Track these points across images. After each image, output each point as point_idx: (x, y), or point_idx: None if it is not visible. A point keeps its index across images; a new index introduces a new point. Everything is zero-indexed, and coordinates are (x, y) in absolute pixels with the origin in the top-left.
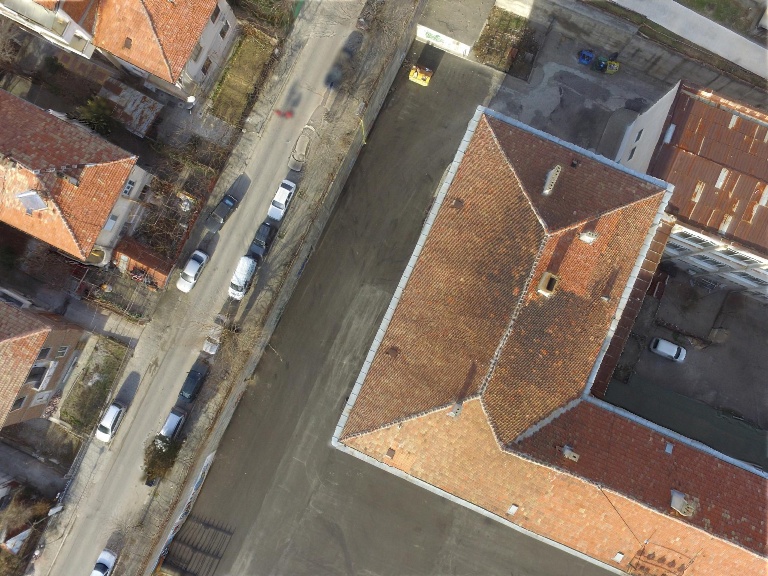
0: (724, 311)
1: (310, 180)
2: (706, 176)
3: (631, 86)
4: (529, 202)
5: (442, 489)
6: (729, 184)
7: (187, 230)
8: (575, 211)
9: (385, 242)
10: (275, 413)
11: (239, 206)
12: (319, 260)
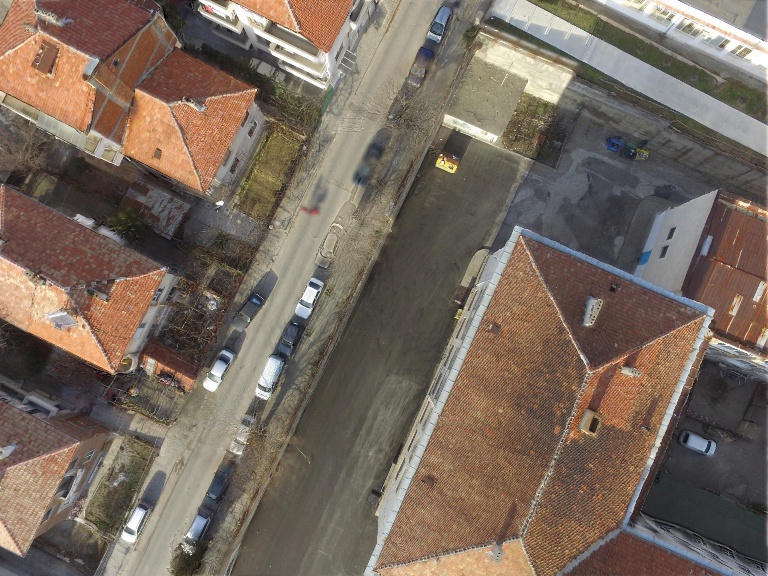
0: (754, 403)
1: (338, 277)
2: (744, 289)
3: (660, 173)
4: (570, 335)
5: None
6: (767, 297)
7: (215, 333)
8: (616, 344)
9: (411, 331)
10: (300, 505)
11: (266, 303)
12: (344, 350)
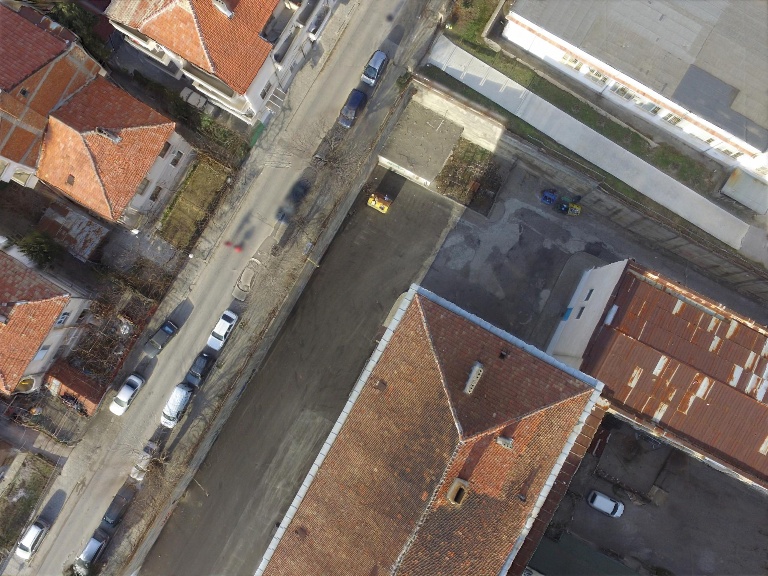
0: (667, 468)
1: (253, 311)
2: (644, 362)
3: (592, 229)
4: (448, 401)
5: None
6: (667, 372)
7: (121, 360)
8: (495, 413)
9: (330, 368)
10: (204, 533)
11: (180, 331)
12: (262, 381)
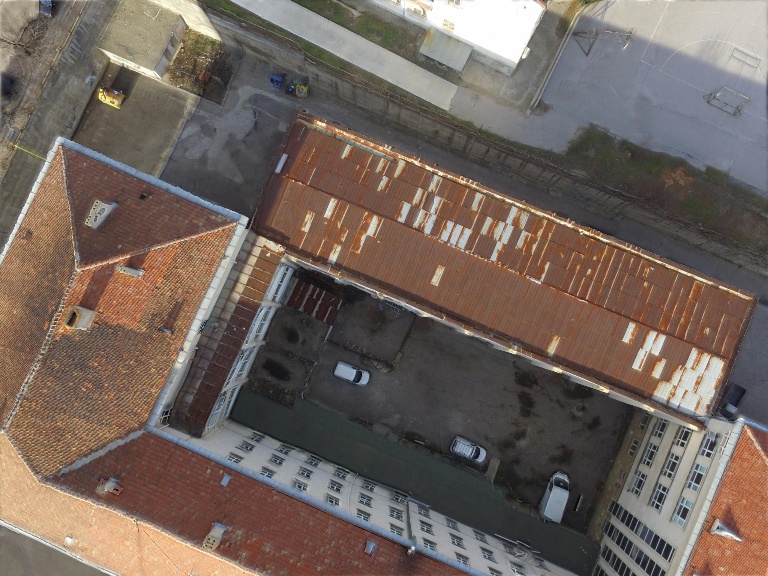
0: (411, 335)
1: None
2: (315, 206)
3: (326, 110)
4: (72, 236)
5: (3, 520)
6: (338, 214)
7: None
8: (120, 245)
9: None
10: None
11: None
12: None
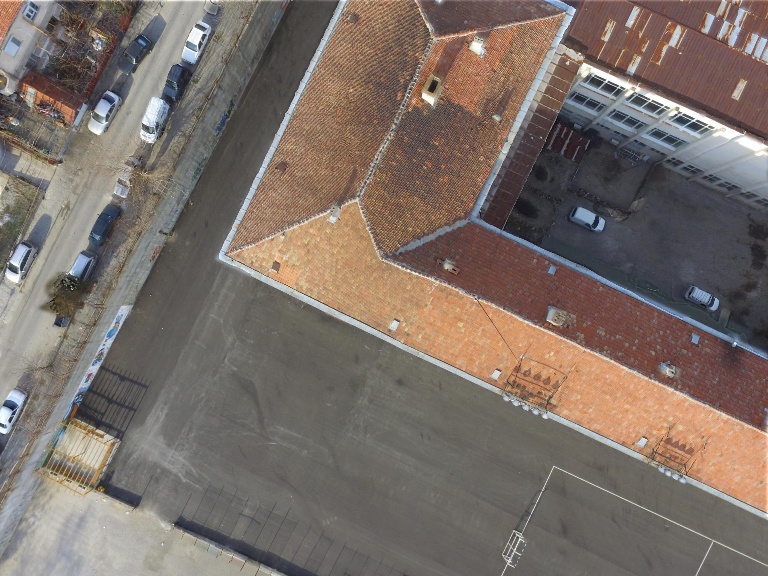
0: (646, 184)
1: (226, 24)
2: (617, 14)
3: None
4: (419, 8)
5: (327, 304)
6: (640, 23)
7: (95, 64)
8: (466, 20)
9: None
10: (193, 270)
11: (153, 49)
12: (241, 119)
